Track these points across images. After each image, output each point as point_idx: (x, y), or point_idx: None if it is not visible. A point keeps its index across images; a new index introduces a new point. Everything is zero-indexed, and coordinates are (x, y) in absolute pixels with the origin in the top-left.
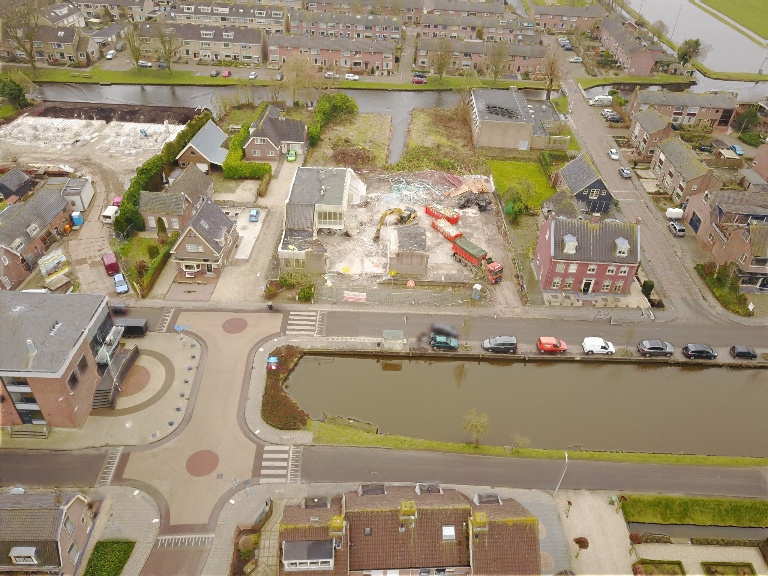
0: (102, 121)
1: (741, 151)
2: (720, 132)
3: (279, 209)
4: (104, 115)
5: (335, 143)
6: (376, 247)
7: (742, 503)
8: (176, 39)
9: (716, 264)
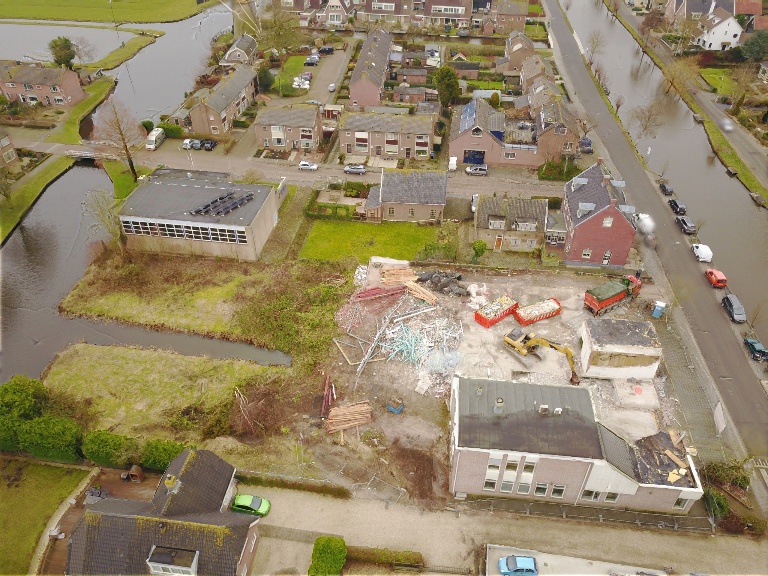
0: None
1: (319, 102)
2: None
3: (475, 527)
4: None
5: (207, 426)
6: None
7: None
8: None
9: (533, 168)
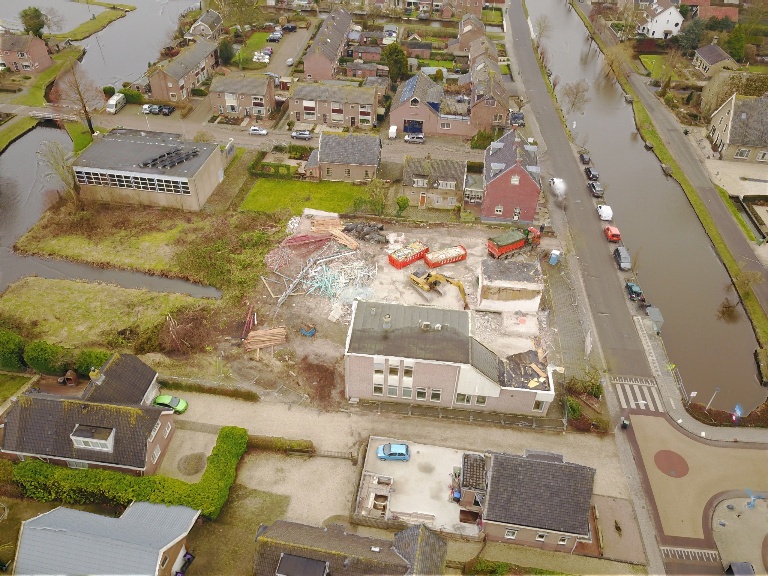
0: None
1: (275, 75)
2: (224, 72)
3: (363, 424)
4: None
5: (139, 343)
6: (478, 320)
7: None
8: None
9: (467, 138)
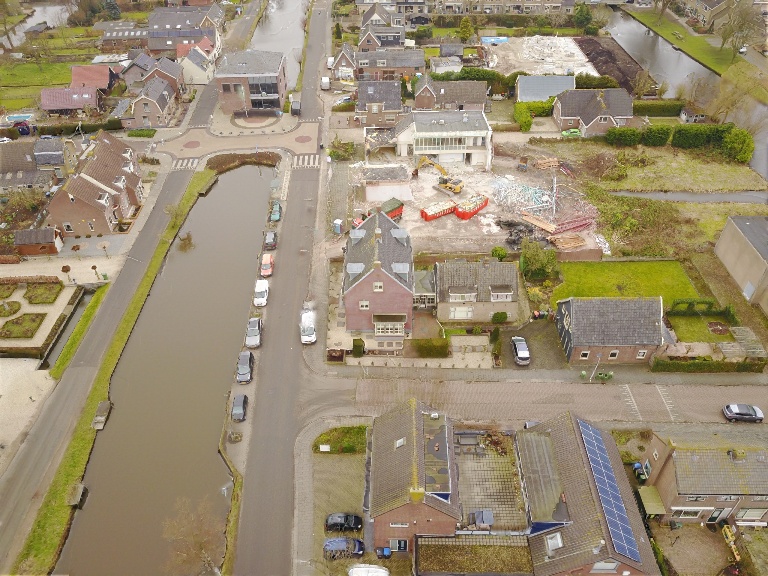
0: (585, 59)
1: None
2: None
3: None
4: (595, 56)
5: None
6: None
7: (75, 346)
8: (759, 29)
9: None
